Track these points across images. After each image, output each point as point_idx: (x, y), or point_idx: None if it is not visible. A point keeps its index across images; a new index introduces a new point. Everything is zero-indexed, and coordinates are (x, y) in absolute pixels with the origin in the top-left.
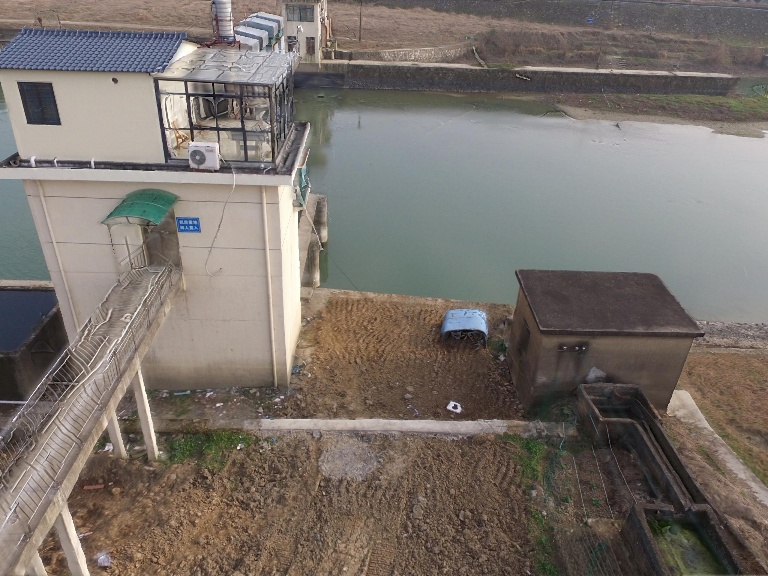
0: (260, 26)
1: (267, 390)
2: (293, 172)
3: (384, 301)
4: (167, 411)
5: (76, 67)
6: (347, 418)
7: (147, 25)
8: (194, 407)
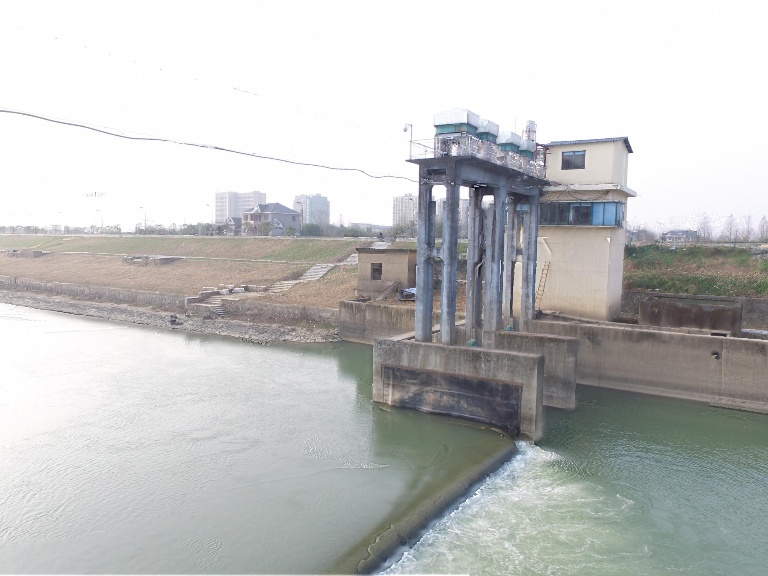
0: None
1: None
2: None
3: None
4: None
5: None
6: None
7: None
8: None
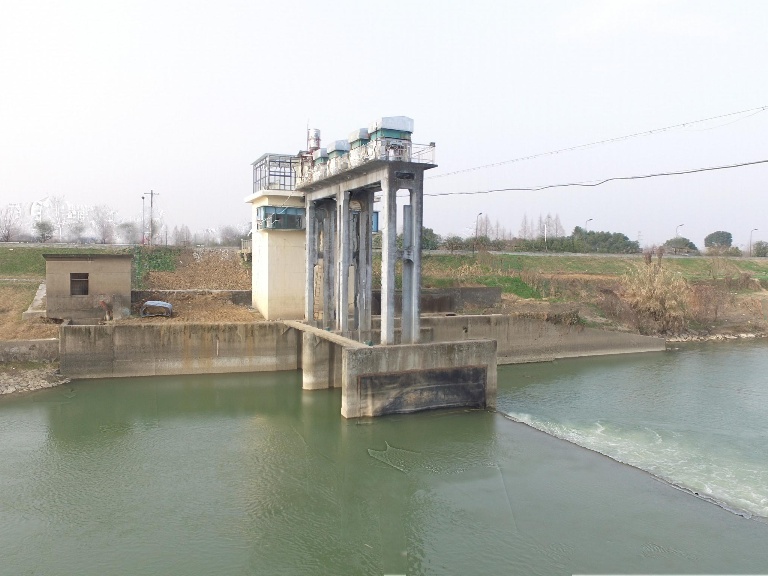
0: None
1: None
2: None
3: None
4: None
5: None
6: None
7: None
8: None
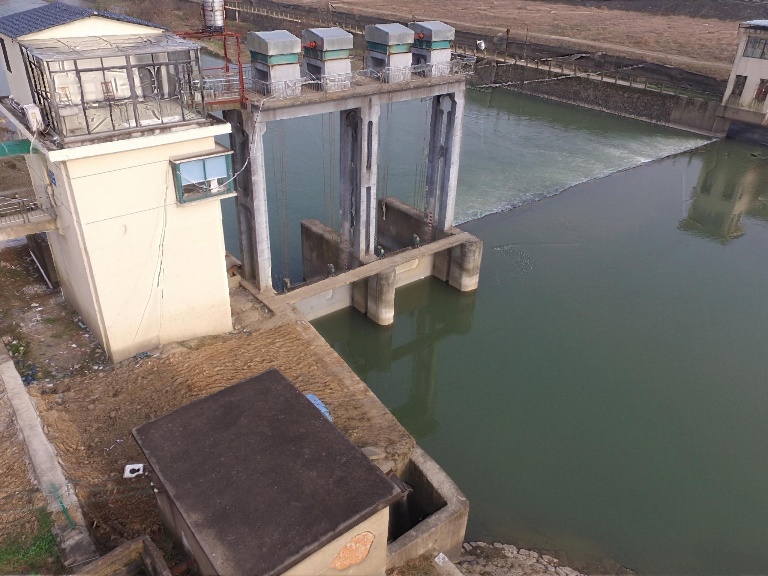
0: (380, 31)
1: (104, 356)
2: (64, 150)
3: (317, 353)
4: (56, 330)
5: (2, 28)
6: (69, 409)
7: (636, 48)
8: (66, 337)
